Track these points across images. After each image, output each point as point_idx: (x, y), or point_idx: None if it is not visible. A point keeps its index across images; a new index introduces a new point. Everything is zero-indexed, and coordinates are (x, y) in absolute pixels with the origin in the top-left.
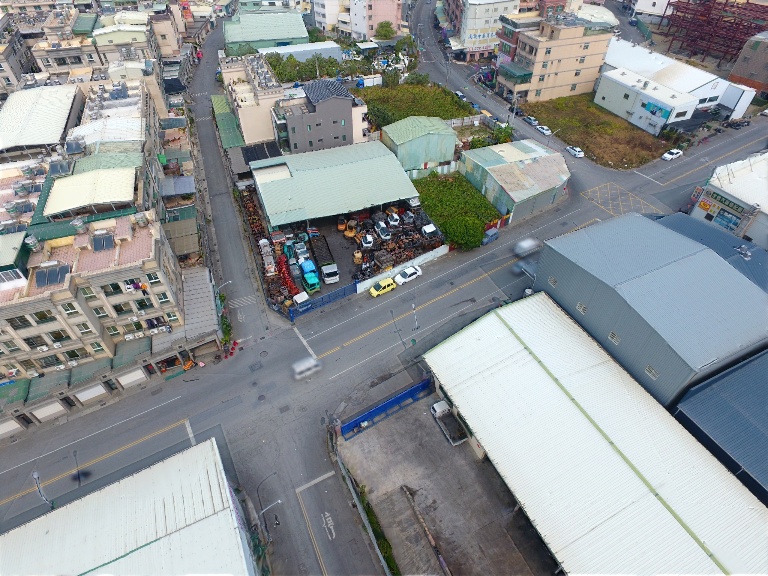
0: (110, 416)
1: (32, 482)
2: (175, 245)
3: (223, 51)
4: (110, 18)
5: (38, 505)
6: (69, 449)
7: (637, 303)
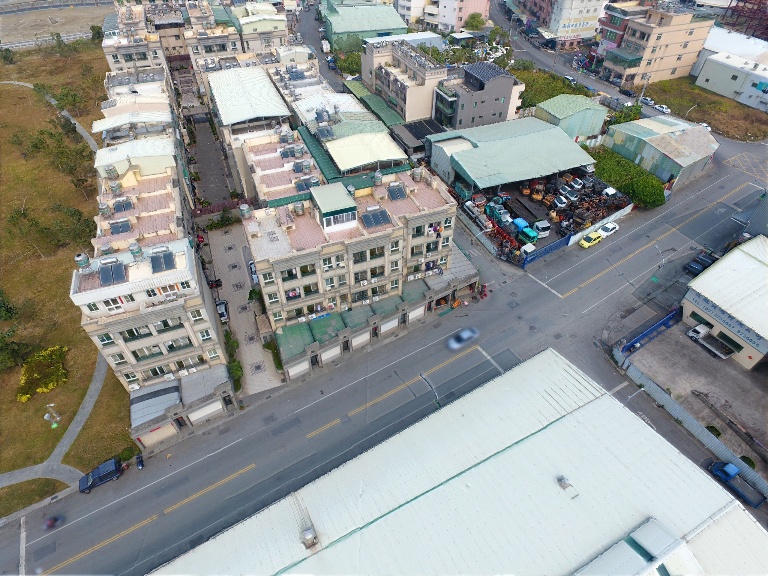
0: (408, 344)
1: (373, 395)
2: None
3: (326, 42)
4: (241, 9)
5: (389, 412)
6: (389, 370)
7: None
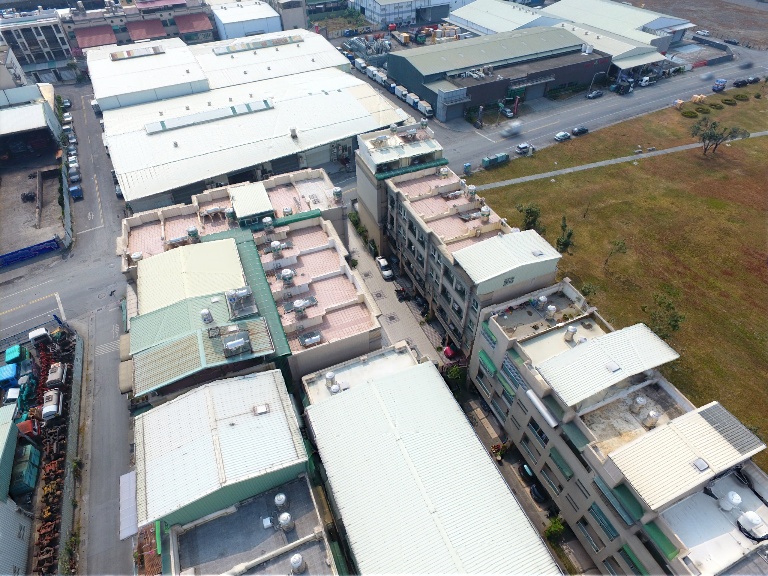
0: None
1: None
2: None
3: None
4: None
5: None
6: None
7: None
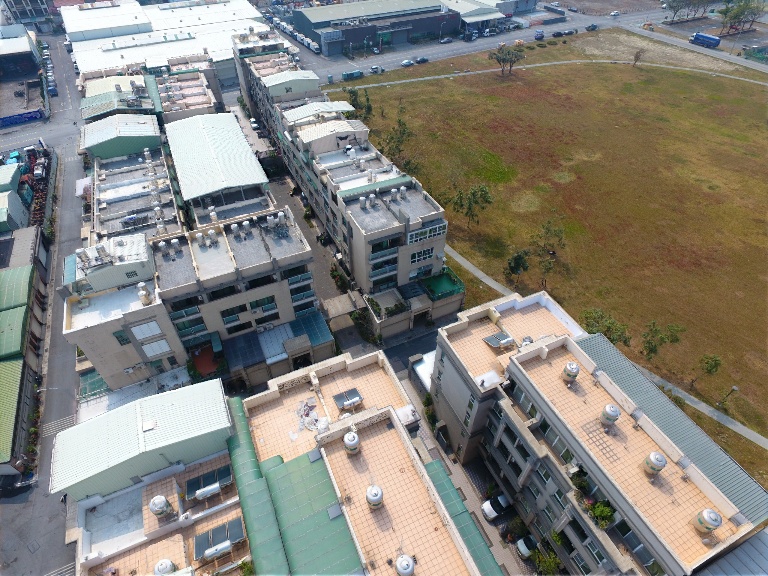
0: None
1: None
2: None
3: None
4: None
5: None
6: None
7: None
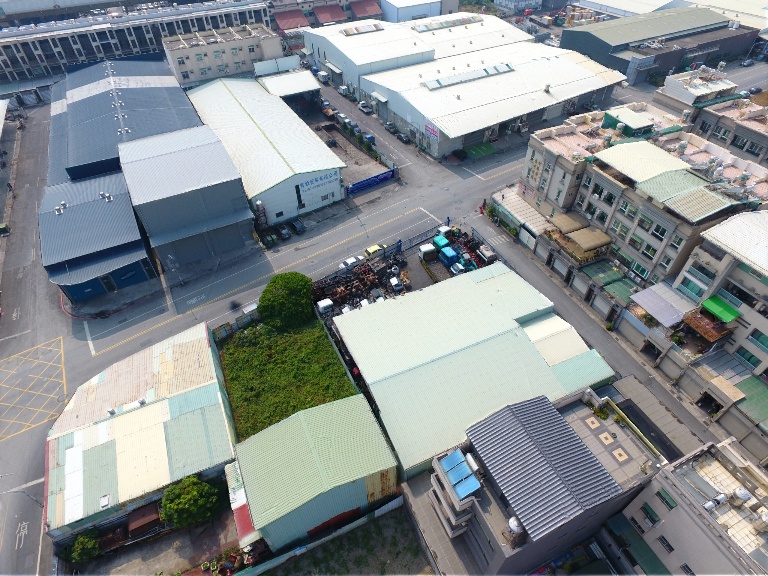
0: None
1: None
2: (571, 218)
3: None
4: None
5: None
6: None
7: (213, 137)
